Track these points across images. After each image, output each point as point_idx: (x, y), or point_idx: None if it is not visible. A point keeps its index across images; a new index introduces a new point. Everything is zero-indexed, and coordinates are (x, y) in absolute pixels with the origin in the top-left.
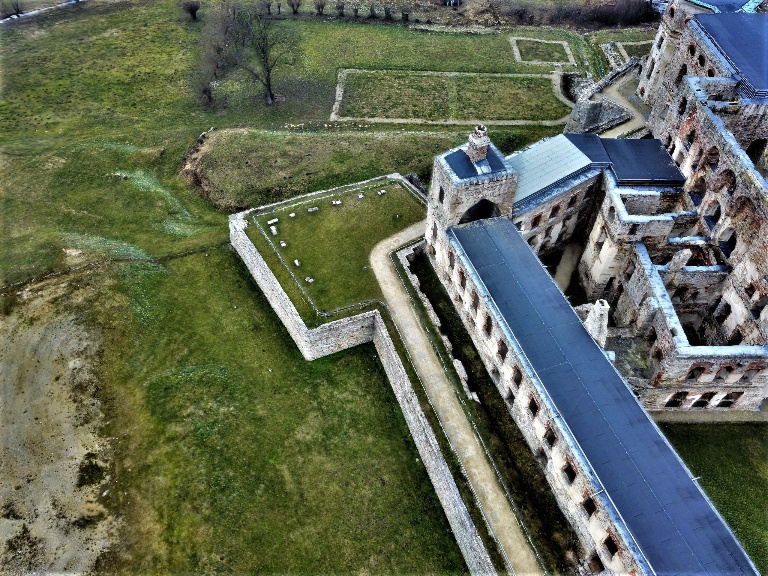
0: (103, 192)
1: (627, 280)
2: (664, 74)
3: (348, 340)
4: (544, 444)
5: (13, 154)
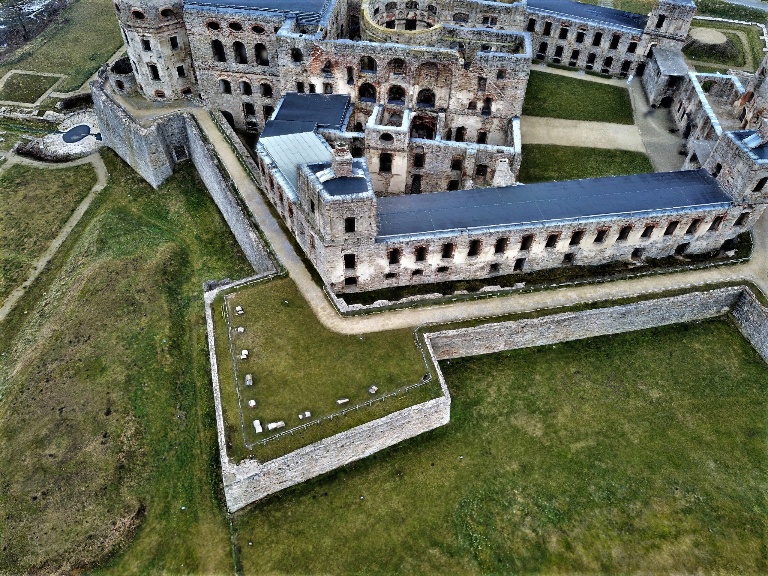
0: None
1: (421, 168)
2: (174, 66)
3: None
4: (572, 248)
5: None
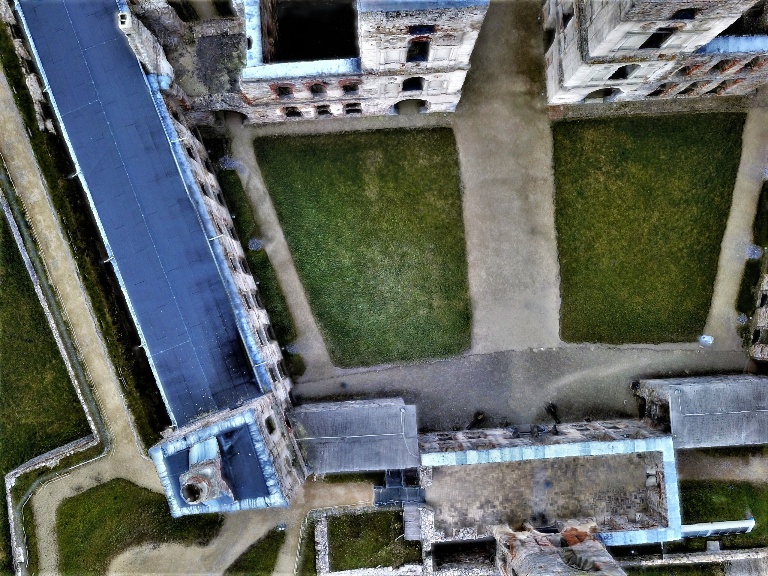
0: None
1: None
2: None
3: None
4: None
5: None
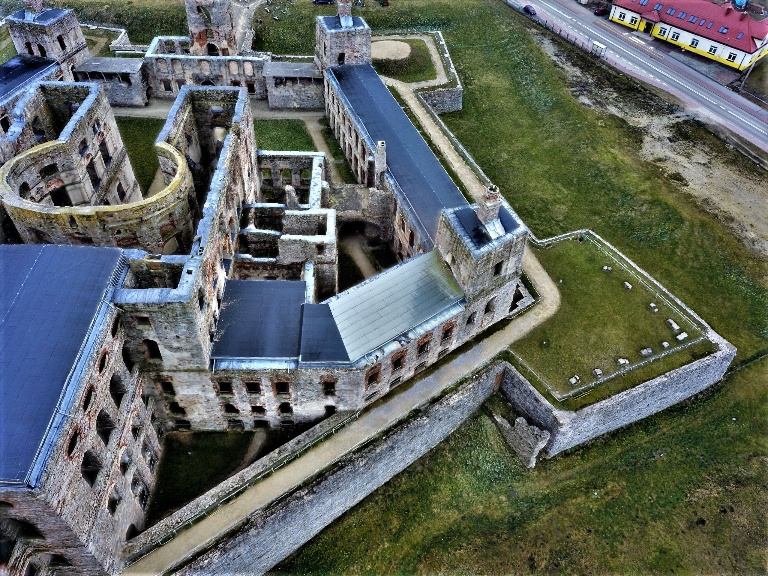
0: None
1: None
2: None
3: None
4: None
5: None
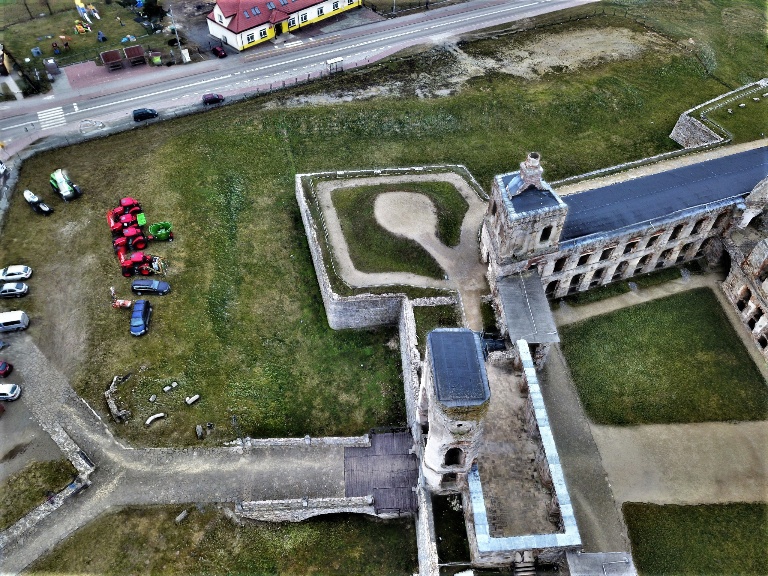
0: (758, 52)
1: None
2: None
3: (694, 144)
4: None
5: (764, 17)
